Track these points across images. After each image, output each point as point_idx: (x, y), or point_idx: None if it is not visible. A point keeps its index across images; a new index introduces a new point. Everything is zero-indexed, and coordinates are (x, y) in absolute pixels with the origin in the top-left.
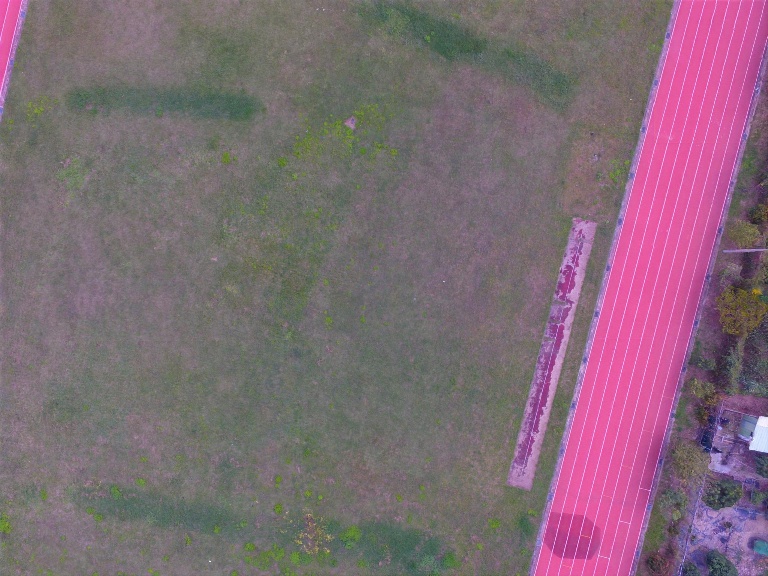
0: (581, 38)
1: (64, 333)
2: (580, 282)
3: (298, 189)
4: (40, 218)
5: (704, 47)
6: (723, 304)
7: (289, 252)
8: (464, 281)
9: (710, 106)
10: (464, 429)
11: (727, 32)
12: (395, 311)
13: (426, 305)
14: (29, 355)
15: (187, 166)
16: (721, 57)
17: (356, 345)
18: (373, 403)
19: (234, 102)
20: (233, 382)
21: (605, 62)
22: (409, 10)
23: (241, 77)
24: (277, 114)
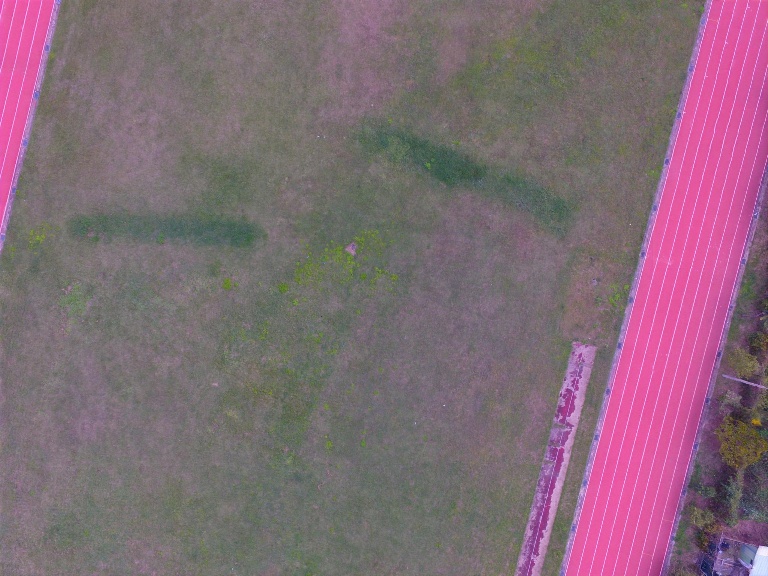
0: (580, 164)
1: (65, 459)
2: (580, 406)
3: (299, 314)
4: (41, 345)
5: (703, 173)
6: (722, 435)
7: (290, 377)
8: (464, 405)
9: (709, 231)
10: (464, 552)
11: (725, 158)
12: (395, 435)
13: (426, 429)
14: (30, 481)
15: (188, 292)
16: (720, 183)
17: (356, 469)
18: (373, 527)
19: (235, 229)
20: (234, 507)
21: (604, 188)
22: (409, 137)
23: (242, 204)
24: (278, 240)
